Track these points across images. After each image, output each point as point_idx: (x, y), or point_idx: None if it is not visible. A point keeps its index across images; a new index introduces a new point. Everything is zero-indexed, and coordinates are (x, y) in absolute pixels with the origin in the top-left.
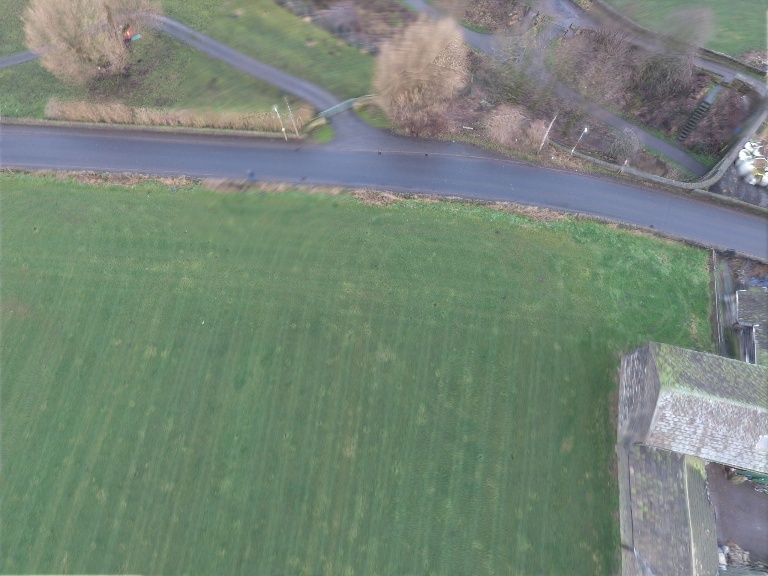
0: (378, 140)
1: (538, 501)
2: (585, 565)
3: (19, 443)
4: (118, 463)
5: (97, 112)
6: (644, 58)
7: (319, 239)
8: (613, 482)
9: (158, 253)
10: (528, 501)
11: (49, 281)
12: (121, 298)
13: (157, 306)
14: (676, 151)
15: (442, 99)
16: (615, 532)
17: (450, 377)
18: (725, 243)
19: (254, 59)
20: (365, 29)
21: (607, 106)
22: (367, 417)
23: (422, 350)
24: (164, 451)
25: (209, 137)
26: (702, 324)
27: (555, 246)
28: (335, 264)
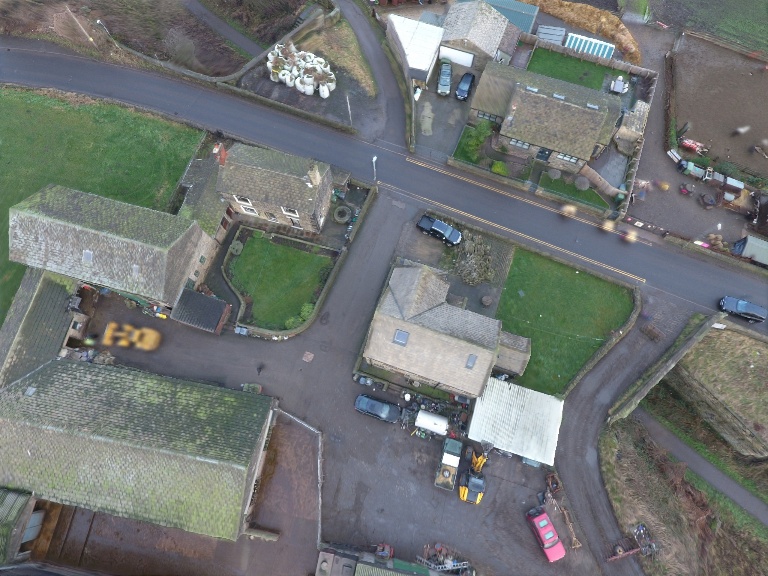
0: None
1: None
2: None
3: None
4: None
5: None
6: None
7: None
8: None
9: None
10: None
11: None
12: None
13: None
14: None
15: None
16: None
17: None
18: (231, 129)
19: None
20: None
21: (231, 22)
22: None
23: None
24: None
25: None
26: (169, 189)
27: (73, 124)
28: None
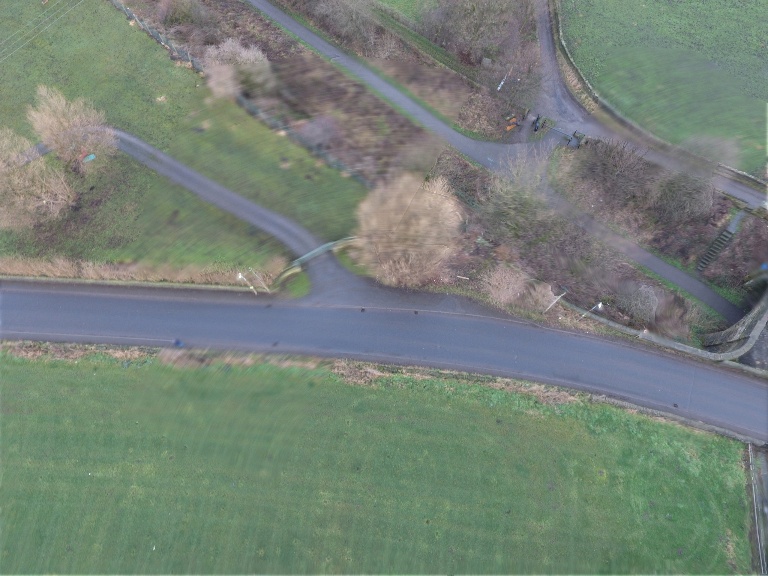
0: (361, 293)
1: None
2: None
3: None
4: None
5: (36, 269)
6: (658, 181)
7: (292, 432)
8: None
9: (103, 452)
10: None
11: None
12: (58, 515)
13: (100, 526)
14: (695, 283)
15: (433, 263)
16: None
17: None
18: (761, 428)
19: (221, 186)
20: (347, 141)
21: (617, 229)
22: None
23: None
24: None
25: (168, 291)
26: (740, 544)
27: (566, 440)
28: (310, 466)
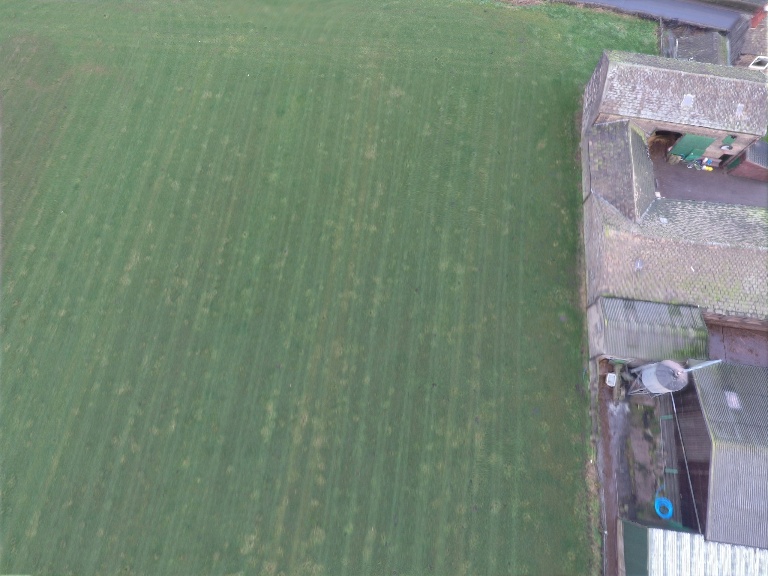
0: None
1: (519, 179)
2: (555, 217)
3: (107, 153)
4: (187, 165)
5: None
6: None
7: (340, 19)
8: (577, 165)
9: (208, 31)
10: (511, 180)
11: (120, 50)
12: (180, 61)
13: (210, 66)
14: None
15: None
16: (579, 196)
17: (449, 105)
18: None
19: None
20: None
21: None
22: (383, 132)
23: (426, 89)
24: (223, 156)
25: None
26: None
27: (533, 20)
28: (354, 35)
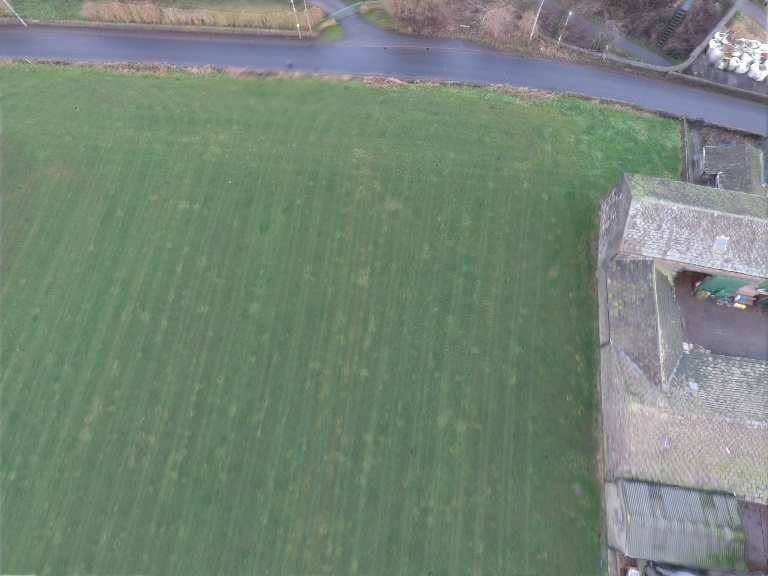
0: (384, 38)
1: (528, 315)
2: (569, 363)
3: (70, 276)
4: (159, 291)
5: (129, 11)
6: None
7: (332, 115)
8: (594, 299)
9: (188, 127)
10: (519, 315)
11: (91, 150)
12: (156, 163)
13: (188, 169)
14: (656, 56)
15: None
16: (595, 337)
17: (450, 221)
18: None
19: None
20: None
21: (593, 18)
22: (377, 254)
23: (425, 201)
24: (199, 282)
25: (230, 36)
26: (674, 178)
27: (544, 118)
28: (347, 134)
